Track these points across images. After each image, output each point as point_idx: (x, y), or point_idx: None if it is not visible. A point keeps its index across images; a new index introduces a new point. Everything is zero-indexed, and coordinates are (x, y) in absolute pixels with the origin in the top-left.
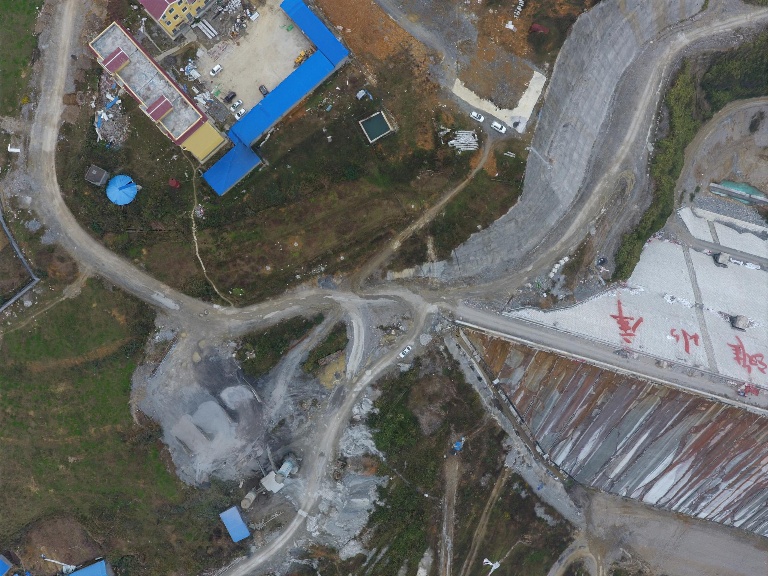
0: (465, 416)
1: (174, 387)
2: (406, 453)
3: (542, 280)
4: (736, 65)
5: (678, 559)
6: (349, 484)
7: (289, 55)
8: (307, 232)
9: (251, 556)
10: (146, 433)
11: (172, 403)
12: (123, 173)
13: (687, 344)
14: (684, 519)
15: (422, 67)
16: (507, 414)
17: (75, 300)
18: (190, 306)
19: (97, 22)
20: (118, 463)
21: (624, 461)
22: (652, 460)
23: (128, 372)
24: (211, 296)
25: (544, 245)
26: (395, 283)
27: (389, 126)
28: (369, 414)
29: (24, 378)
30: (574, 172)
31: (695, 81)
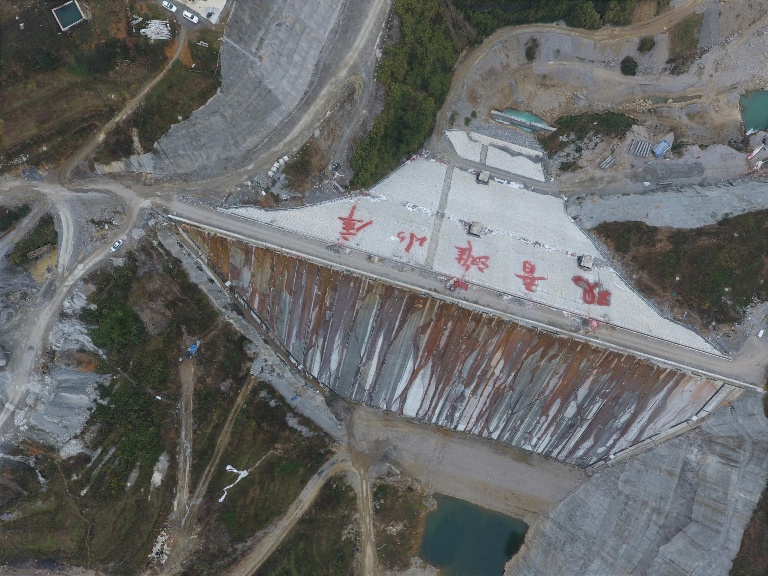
0: (195, 317)
1: None
2: (131, 352)
3: (262, 179)
4: None
5: (446, 475)
6: (57, 377)
7: None
8: (6, 121)
9: None
10: None
11: None
12: None
13: (410, 244)
14: (444, 432)
15: None
16: (250, 320)
17: None
18: None
19: None
20: None
21: (372, 369)
22: (396, 367)
23: None
24: None
25: (266, 145)
26: (107, 177)
27: (82, 14)
28: (83, 309)
29: None
30: (296, 74)
31: None
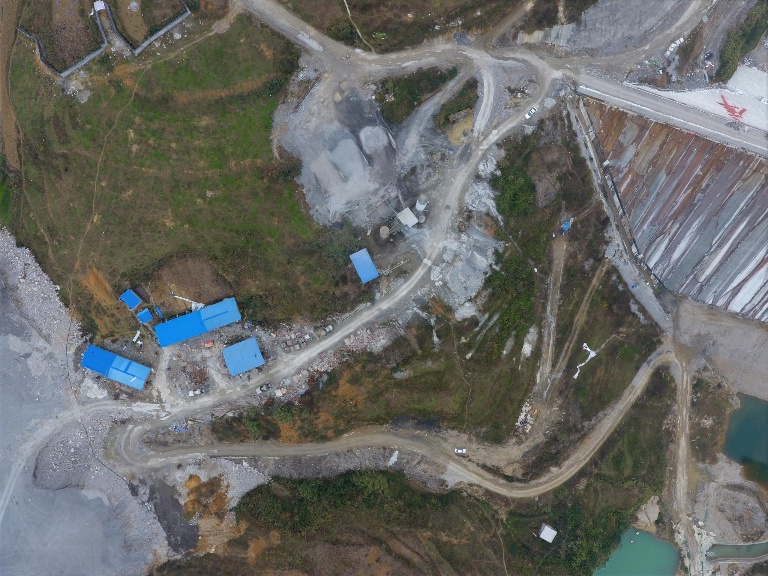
0: (577, 193)
1: (315, 123)
2: (521, 222)
3: (658, 59)
4: None
5: (756, 373)
6: (473, 236)
7: None
8: None
9: (375, 303)
10: (286, 166)
11: (313, 139)
12: None
13: None
14: (766, 328)
15: None
16: (610, 204)
17: (223, 35)
18: (333, 49)
19: None
20: (254, 200)
21: (717, 259)
22: (745, 256)
23: (270, 110)
24: (355, 37)
25: (660, 27)
26: (524, 47)
27: None
28: (492, 174)
29: (169, 109)
30: None
31: None
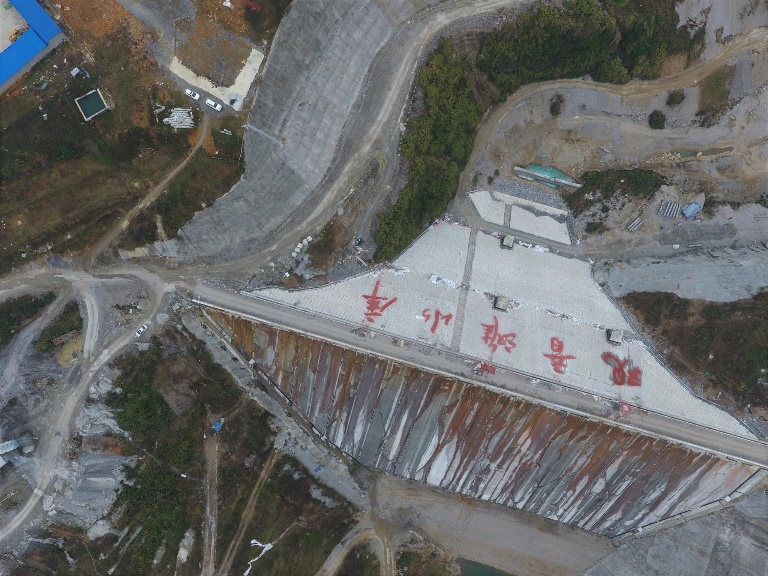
0: (219, 396)
1: None
2: (156, 433)
3: (286, 260)
4: (507, 46)
5: (469, 542)
6: (85, 463)
7: (7, 33)
8: (31, 211)
9: None
10: None
11: None
12: None
13: (435, 324)
14: (468, 501)
15: (140, 45)
16: (273, 395)
17: None
18: None
19: None
20: None
21: (396, 442)
22: (420, 441)
23: None
24: None
25: (289, 225)
26: (131, 262)
27: (105, 104)
28: (109, 393)
29: None
30: (319, 152)
31: (468, 62)
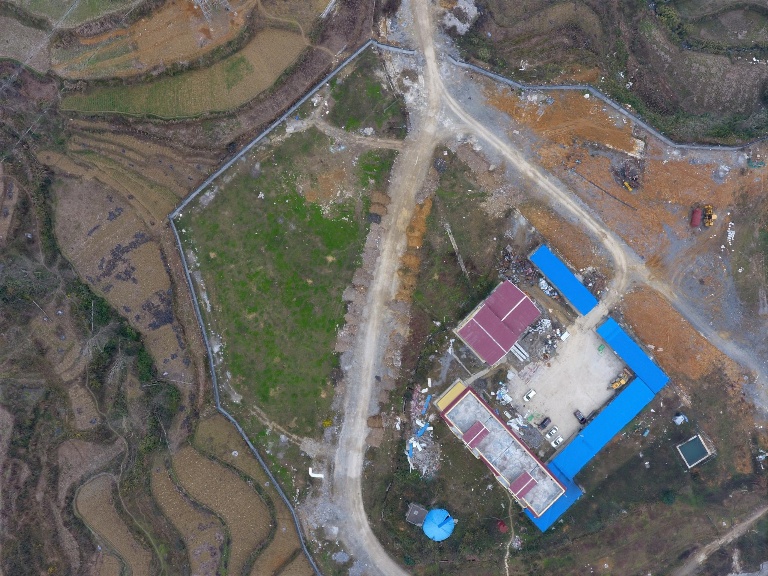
0: None
1: None
2: None
3: None
4: None
5: None
6: None
7: (601, 376)
8: (617, 553)
9: None
10: None
11: None
12: (440, 508)
13: None
14: None
15: (736, 387)
16: None
17: None
18: None
19: (401, 341)
20: None
21: None
22: None
23: None
24: None
25: None
26: None
27: (707, 450)
28: None
29: None
30: None
31: None
